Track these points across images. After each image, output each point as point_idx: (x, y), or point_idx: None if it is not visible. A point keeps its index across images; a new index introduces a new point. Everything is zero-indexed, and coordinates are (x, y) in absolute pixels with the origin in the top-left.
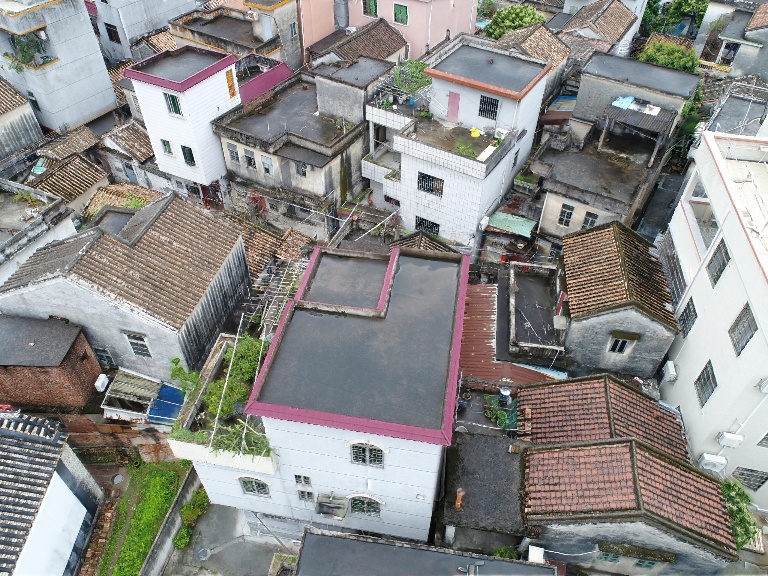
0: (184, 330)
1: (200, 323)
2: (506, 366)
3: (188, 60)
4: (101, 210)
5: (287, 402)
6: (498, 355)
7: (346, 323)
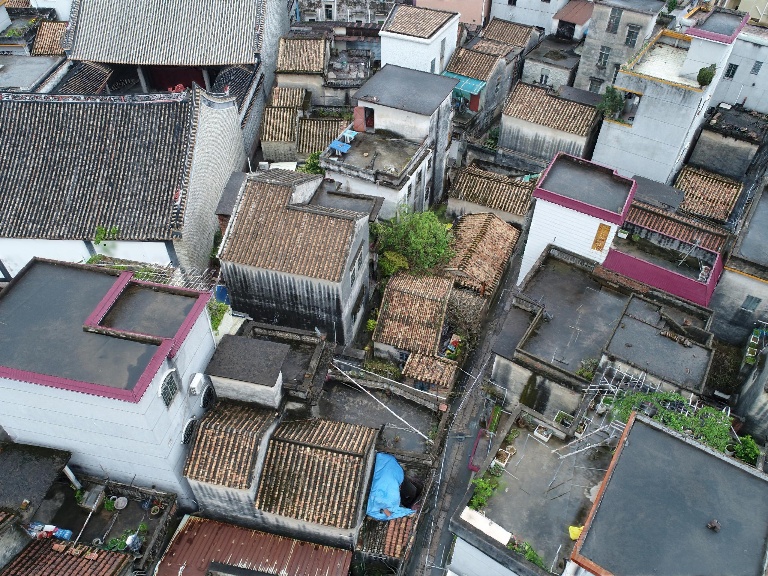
0: (230, 266)
1: (253, 280)
2: (200, 573)
3: (607, 189)
4: (377, 197)
5: (30, 276)
6: (215, 564)
7: (89, 306)
